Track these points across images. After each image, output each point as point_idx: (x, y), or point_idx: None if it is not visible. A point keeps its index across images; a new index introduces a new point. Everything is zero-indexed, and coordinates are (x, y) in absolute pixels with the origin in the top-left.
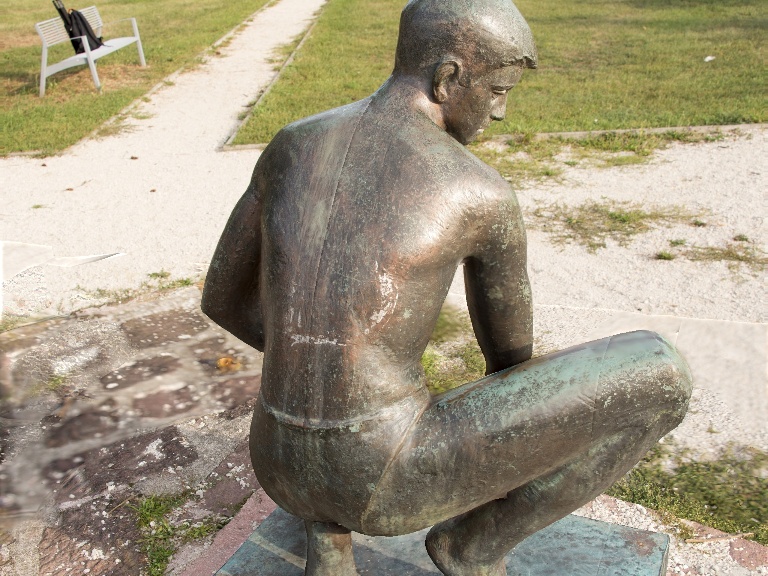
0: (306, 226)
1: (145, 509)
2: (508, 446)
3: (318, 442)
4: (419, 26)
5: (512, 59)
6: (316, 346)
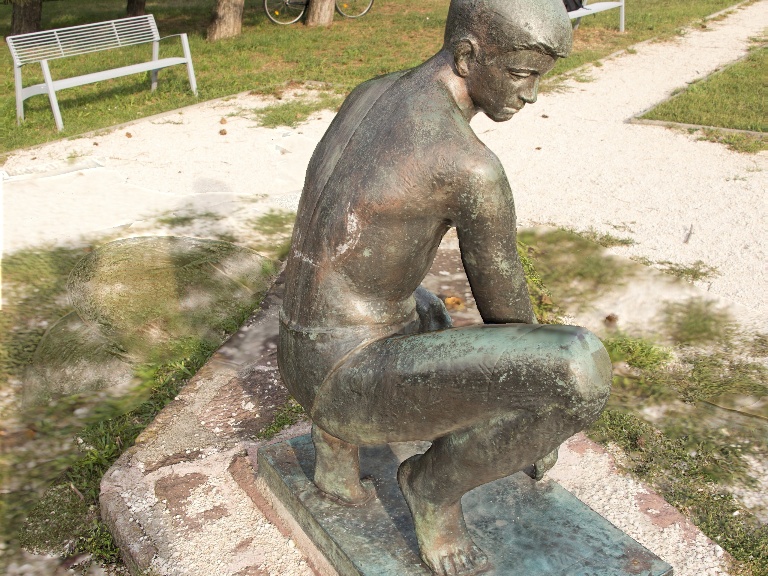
0: (324, 163)
1: None
2: (414, 389)
3: (293, 341)
4: (453, 4)
5: (524, 43)
6: (303, 262)
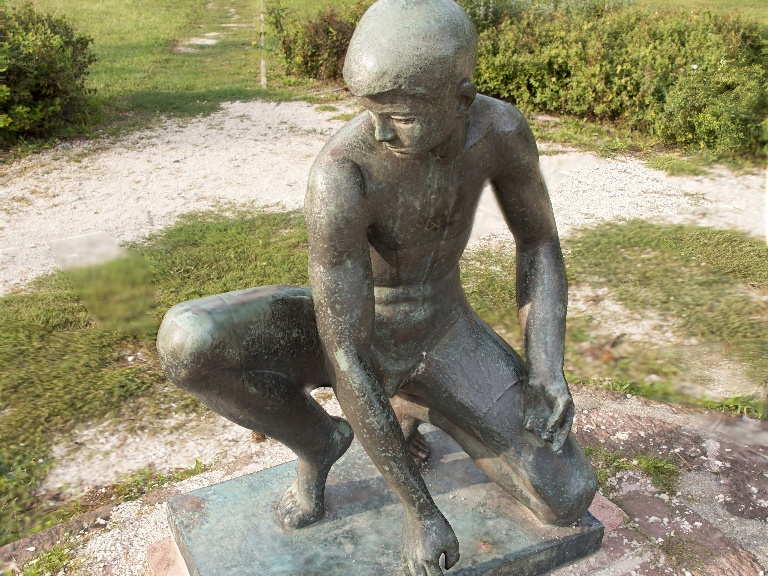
0: None
1: (657, 461)
2: None
3: None
4: None
5: None
6: None
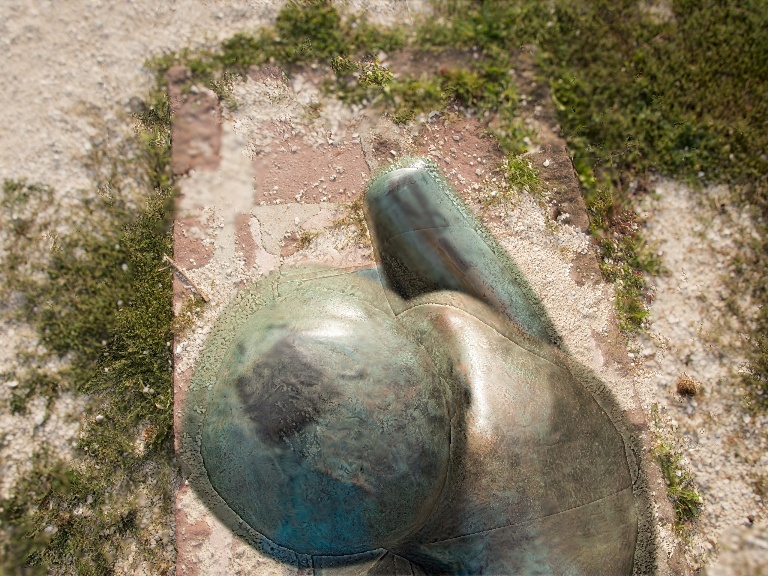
0: None
1: None
2: None
3: None
4: None
5: None
6: None
